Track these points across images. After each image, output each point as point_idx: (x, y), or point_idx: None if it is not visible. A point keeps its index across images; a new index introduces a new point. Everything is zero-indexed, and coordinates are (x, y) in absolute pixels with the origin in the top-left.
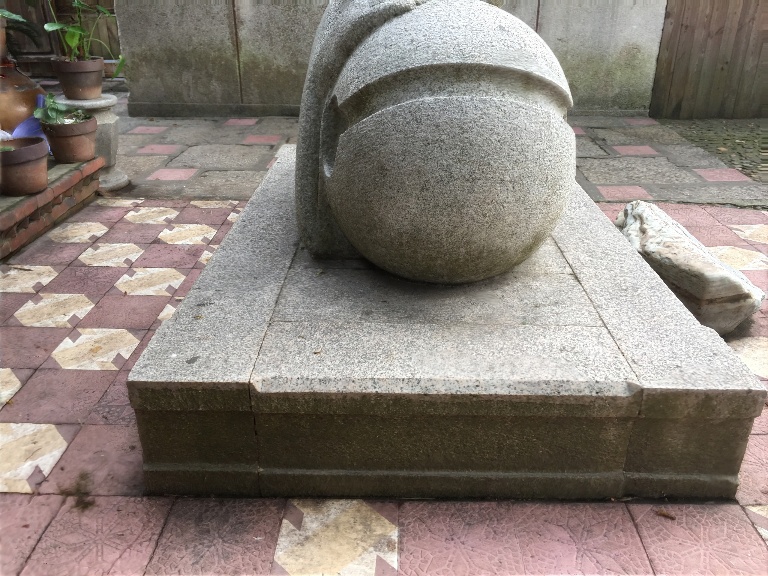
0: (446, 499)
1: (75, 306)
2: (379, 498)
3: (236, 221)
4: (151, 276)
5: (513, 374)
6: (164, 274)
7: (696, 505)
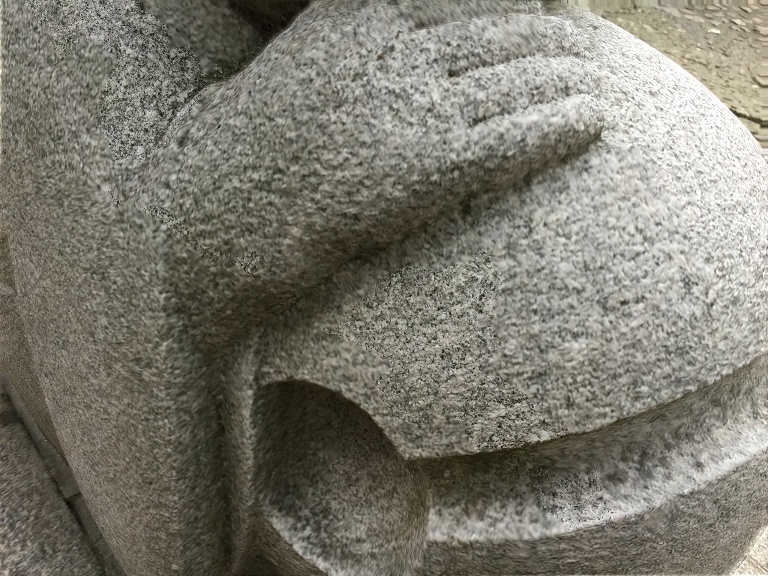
0: None
1: None
2: None
3: None
4: None
5: None
6: None
7: None
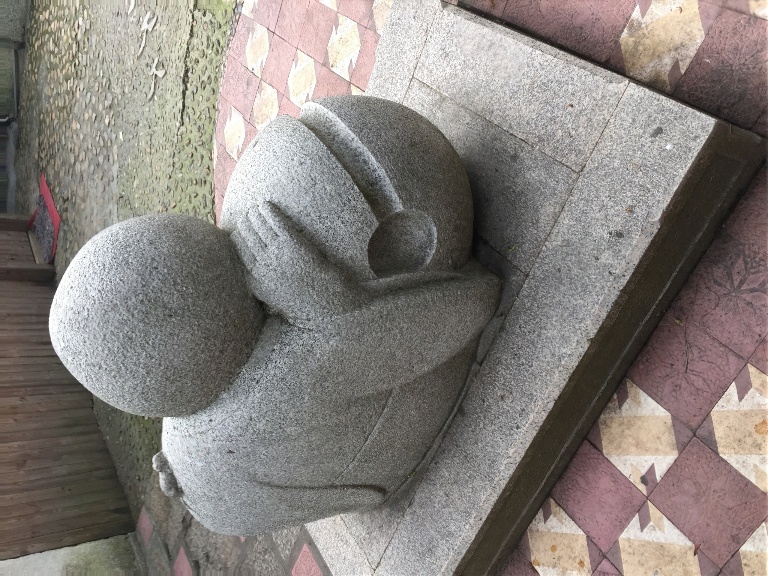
0: (580, 56)
1: (765, 567)
2: (616, 71)
3: (524, 440)
4: (654, 575)
5: (484, 35)
6: (639, 568)
7: (475, 6)
